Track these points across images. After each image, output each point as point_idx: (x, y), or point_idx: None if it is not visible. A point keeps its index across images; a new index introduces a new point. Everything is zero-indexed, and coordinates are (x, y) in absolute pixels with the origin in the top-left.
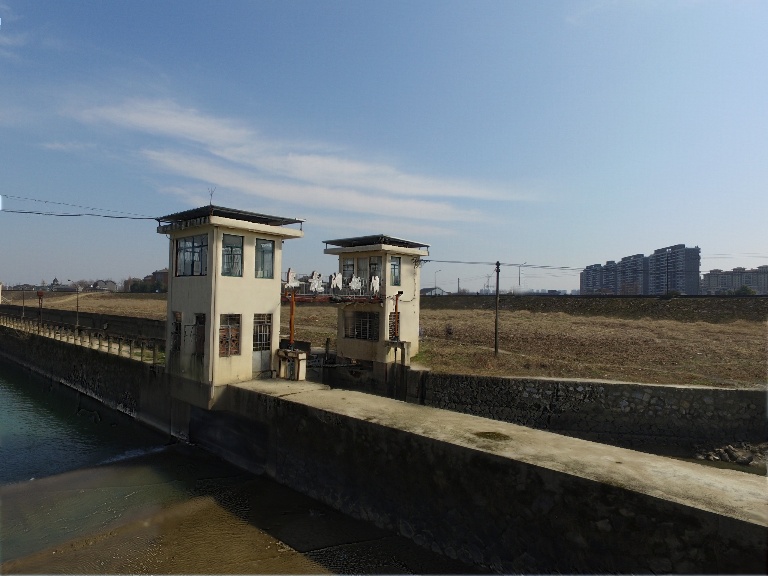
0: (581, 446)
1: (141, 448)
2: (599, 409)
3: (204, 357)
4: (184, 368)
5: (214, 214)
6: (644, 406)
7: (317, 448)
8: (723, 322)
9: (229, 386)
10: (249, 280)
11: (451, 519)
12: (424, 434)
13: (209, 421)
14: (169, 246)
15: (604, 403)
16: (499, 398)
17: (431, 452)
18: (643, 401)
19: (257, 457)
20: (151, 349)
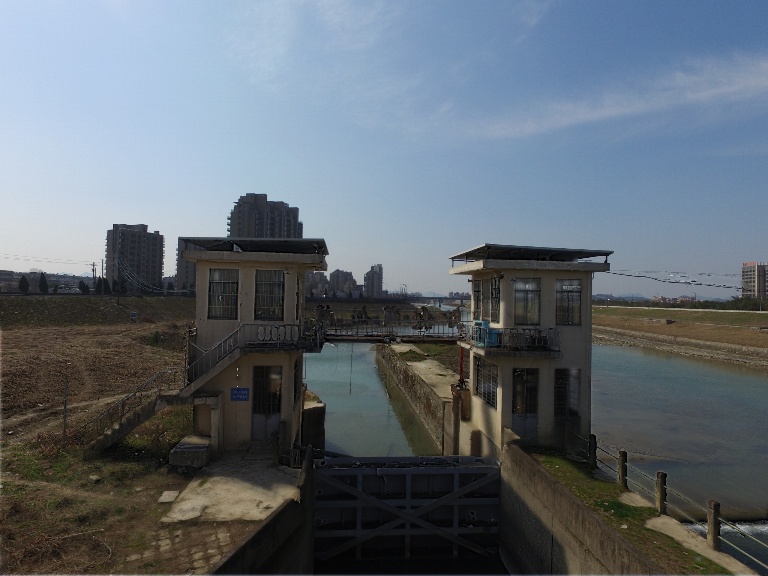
0: (425, 370)
1: None
2: None
3: None
4: None
5: None
6: None
7: None
8: None
9: None
10: None
11: None
12: None
13: None
14: None
15: None
16: None
17: None
18: None
19: None
20: None
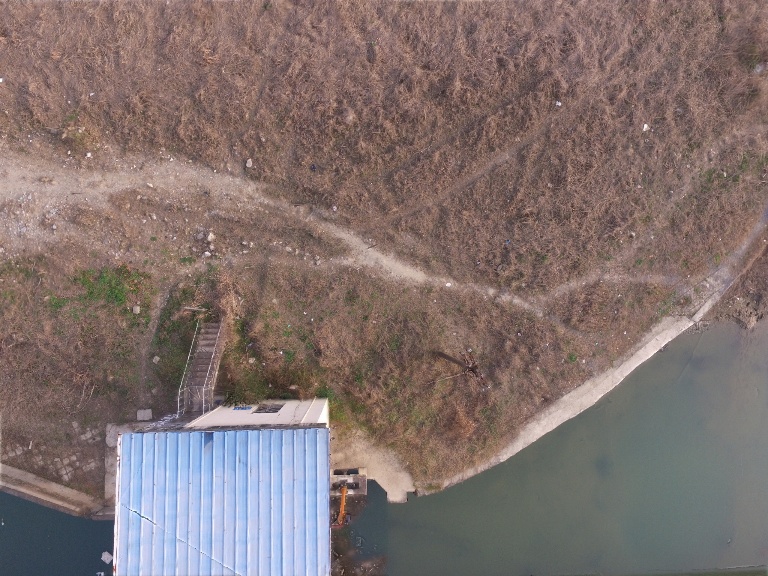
0: None
1: None
2: None
3: None
4: None
5: None
6: None
7: None
8: None
9: None
10: None
11: None
12: None
13: None
14: None
15: None
16: None
17: None
18: None
19: None
20: None
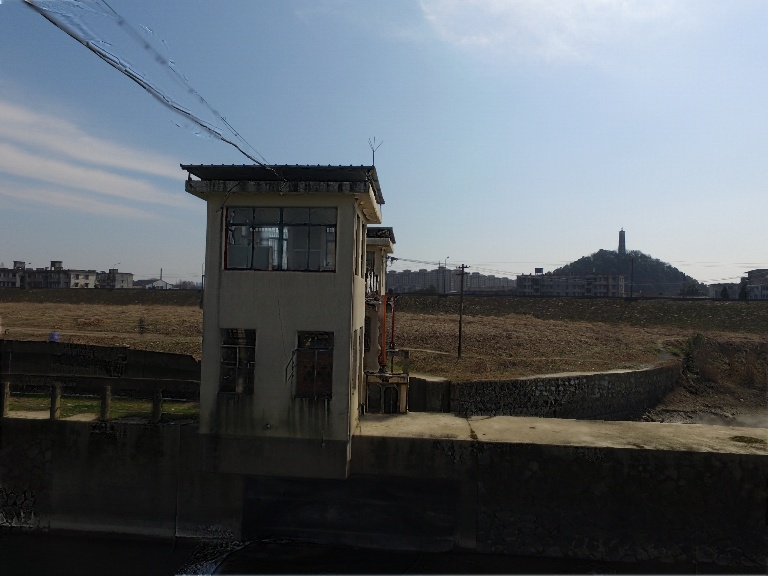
0: None
1: None
2: (585, 398)
3: (333, 399)
4: (268, 421)
5: (341, 179)
6: (606, 391)
7: (562, 494)
8: (495, 316)
9: (360, 437)
10: (359, 280)
11: (763, 529)
12: (722, 451)
13: (305, 496)
14: (208, 217)
15: (587, 392)
16: (518, 400)
17: (740, 468)
18: (605, 387)
19: (436, 528)
20: (88, 395)
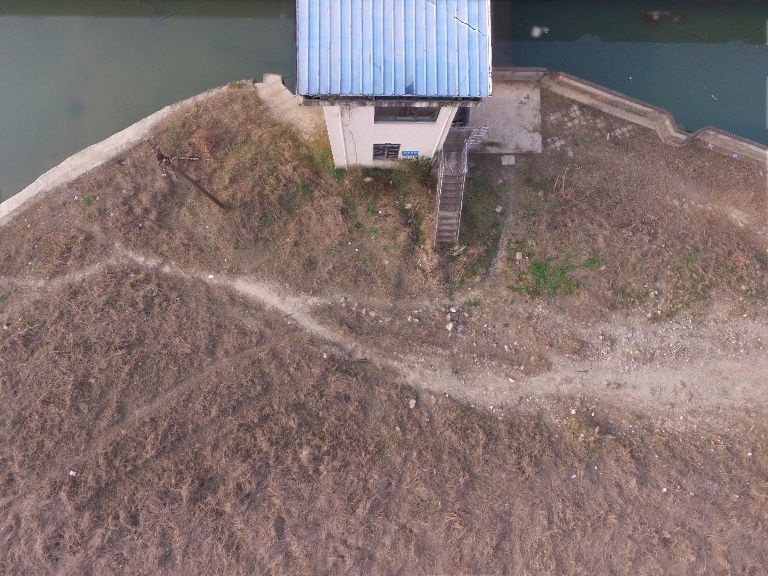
0: None
1: (607, 40)
2: None
3: None
4: None
5: None
6: None
7: None
8: None
9: None
10: None
11: None
12: None
13: None
14: None
15: None
16: None
17: None
18: None
19: None
20: None
